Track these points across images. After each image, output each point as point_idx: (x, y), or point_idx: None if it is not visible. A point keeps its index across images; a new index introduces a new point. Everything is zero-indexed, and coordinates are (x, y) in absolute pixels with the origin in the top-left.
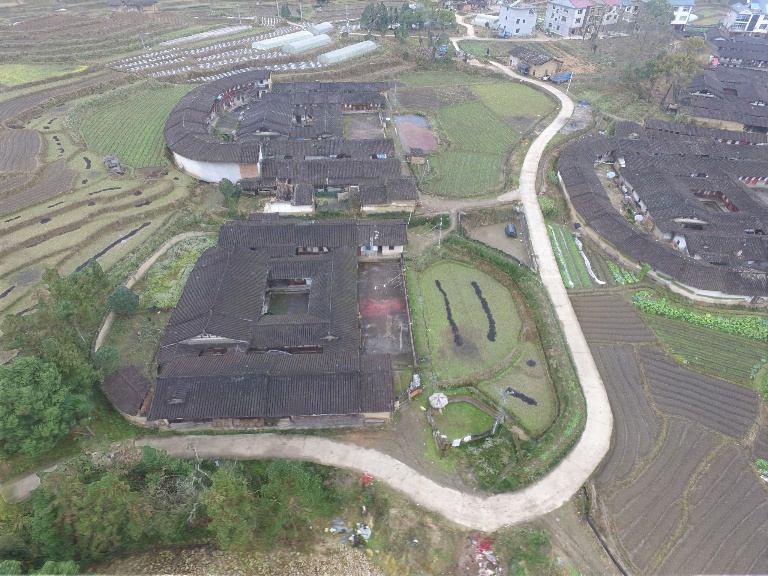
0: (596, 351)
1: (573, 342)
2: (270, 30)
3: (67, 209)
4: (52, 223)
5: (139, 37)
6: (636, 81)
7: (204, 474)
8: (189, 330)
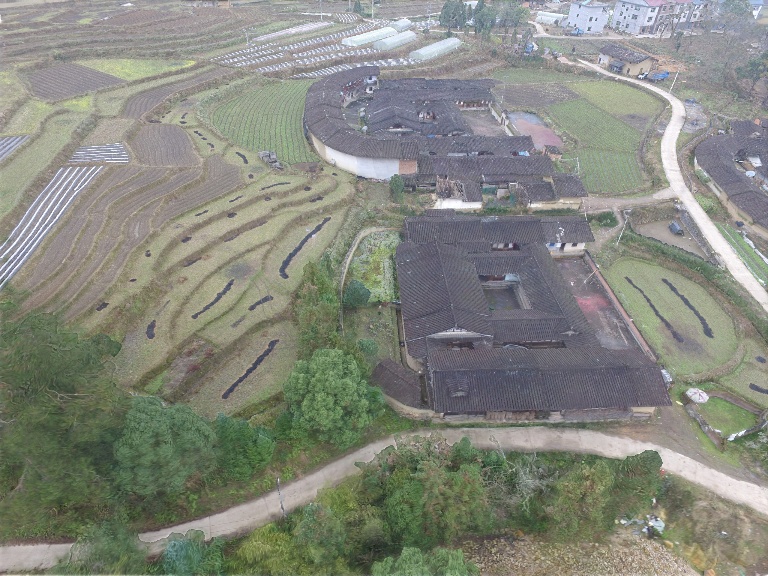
0: None
1: None
2: (353, 26)
3: (248, 204)
4: (239, 217)
5: (232, 32)
6: (732, 80)
7: (514, 465)
8: (434, 324)
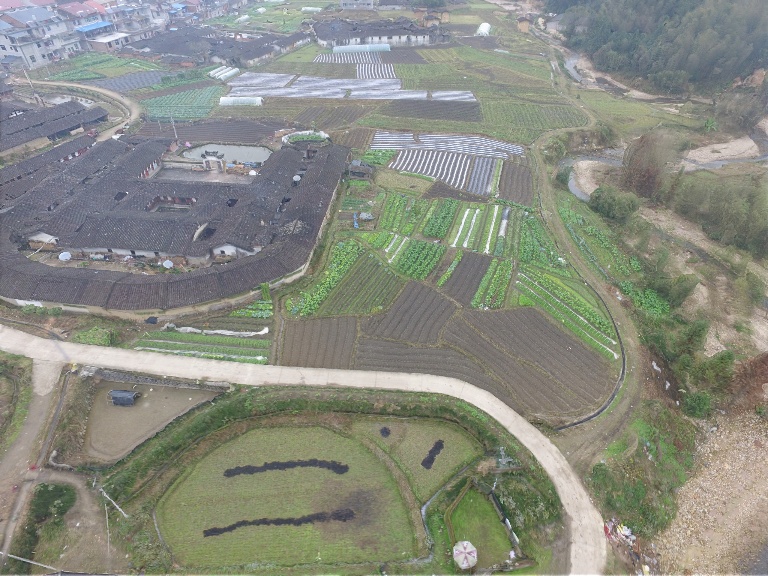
0: (366, 367)
1: (361, 382)
2: None
3: None
4: None
5: None
6: None
7: None
8: None
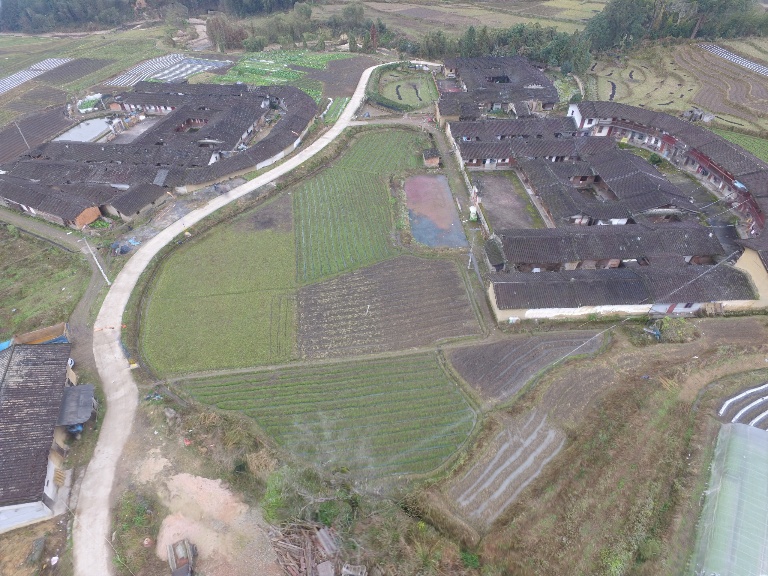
0: None
1: None
2: None
3: None
4: (665, 92)
5: None
6: None
7: None
8: None
